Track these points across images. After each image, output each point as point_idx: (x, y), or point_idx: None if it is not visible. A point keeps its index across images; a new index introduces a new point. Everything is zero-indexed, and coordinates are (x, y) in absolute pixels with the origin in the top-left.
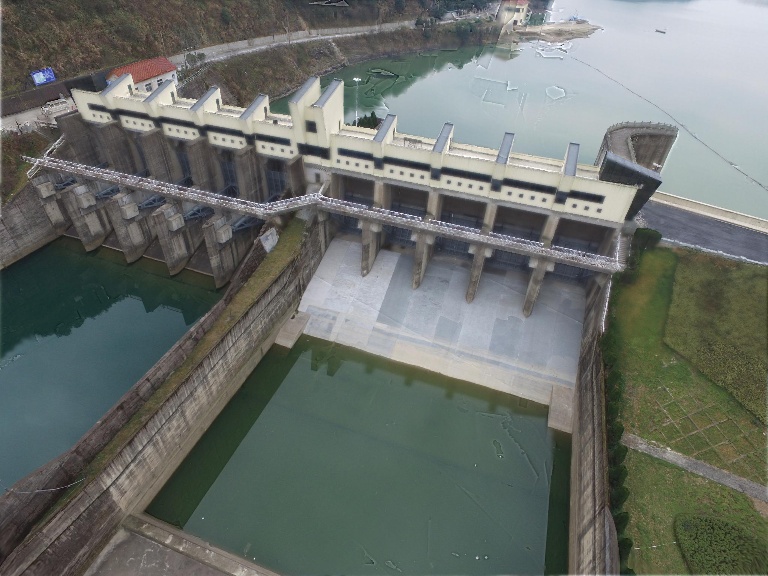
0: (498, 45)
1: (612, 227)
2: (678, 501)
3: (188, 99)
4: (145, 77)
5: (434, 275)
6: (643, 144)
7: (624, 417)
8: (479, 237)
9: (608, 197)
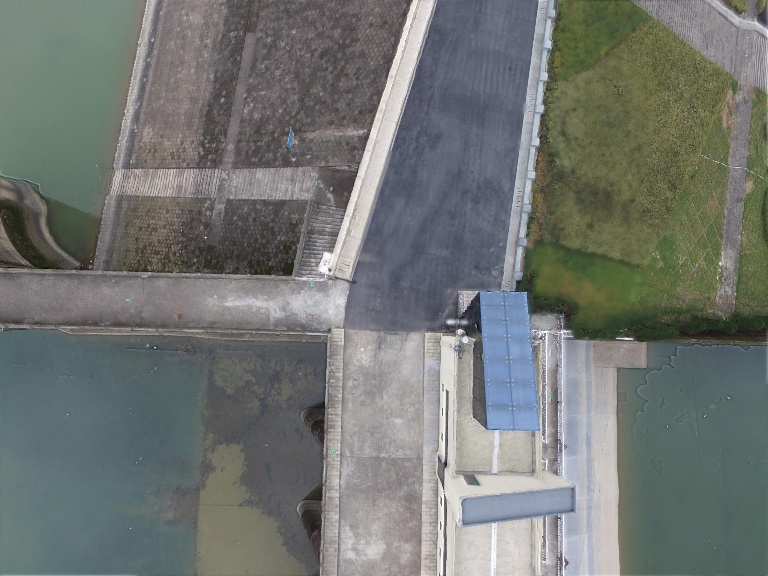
0: None
1: None
2: (766, 262)
3: None
4: None
5: None
6: None
7: (703, 308)
8: None
9: None
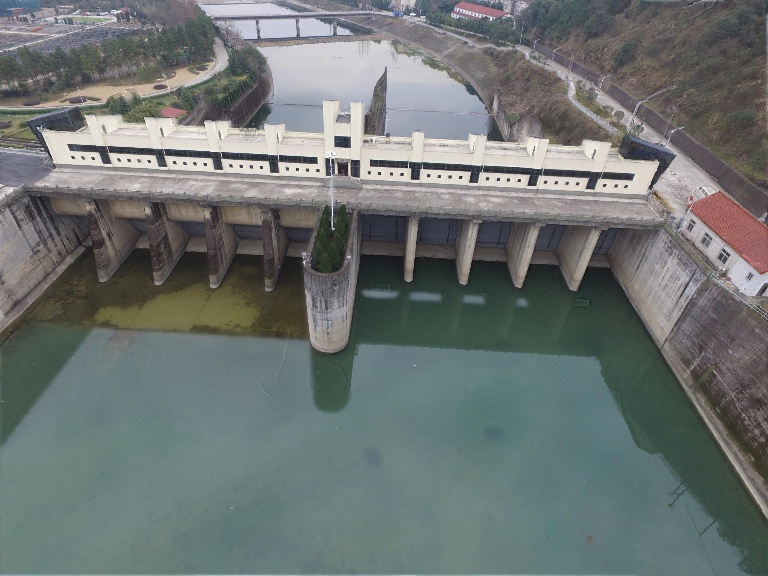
0: None
1: None
2: None
3: (519, 155)
4: (711, 223)
5: None
6: None
7: None
8: None
9: None
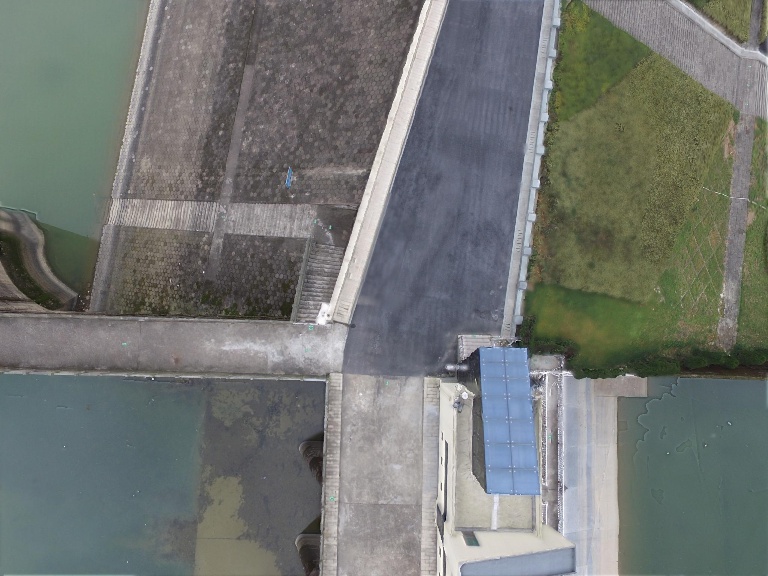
0: None
1: None
2: (767, 293)
3: None
4: None
5: None
6: None
7: (705, 341)
8: None
9: None
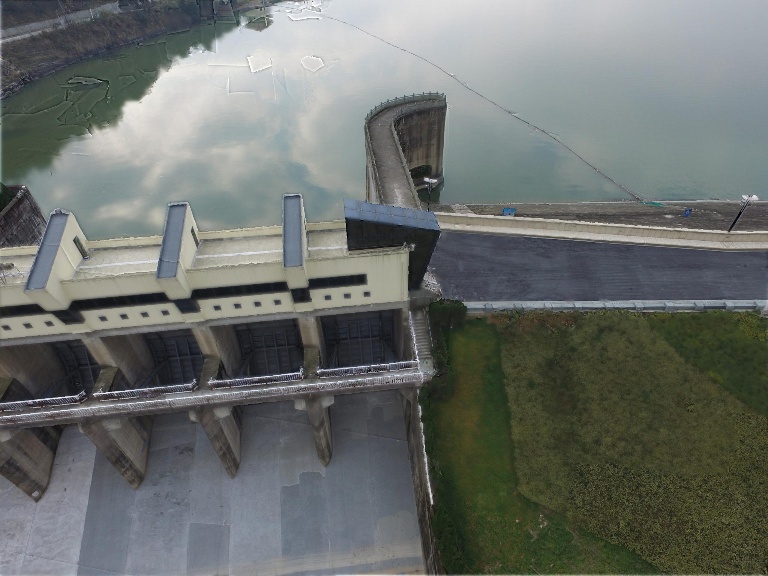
0: (219, 19)
1: (395, 308)
2: None
3: None
4: None
5: (166, 445)
6: (413, 125)
7: None
8: (191, 400)
9: (371, 274)
